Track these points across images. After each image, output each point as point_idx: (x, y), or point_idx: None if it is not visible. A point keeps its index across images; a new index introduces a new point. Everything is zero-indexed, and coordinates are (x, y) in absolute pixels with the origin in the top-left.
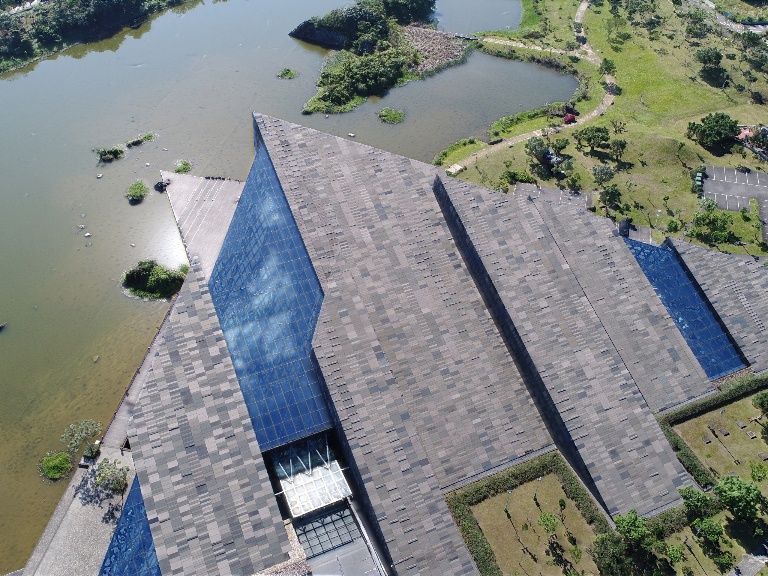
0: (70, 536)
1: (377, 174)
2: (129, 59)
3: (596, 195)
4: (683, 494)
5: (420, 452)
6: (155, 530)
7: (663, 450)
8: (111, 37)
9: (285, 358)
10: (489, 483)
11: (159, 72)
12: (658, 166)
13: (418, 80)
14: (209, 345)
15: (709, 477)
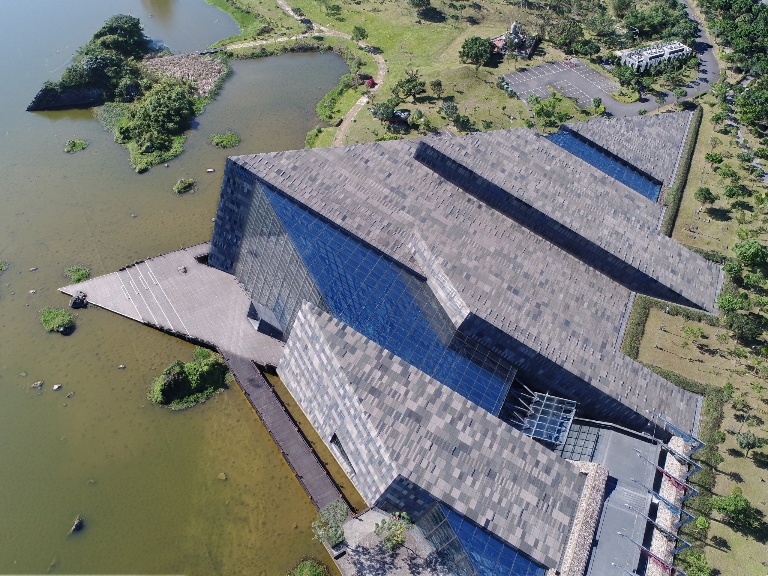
0: None
1: (368, 165)
2: None
3: (452, 129)
4: (729, 269)
5: (596, 340)
6: (495, 529)
7: (689, 254)
8: None
9: (443, 342)
10: (631, 338)
11: None
12: (471, 90)
13: (211, 102)
14: (389, 366)
15: (719, 255)
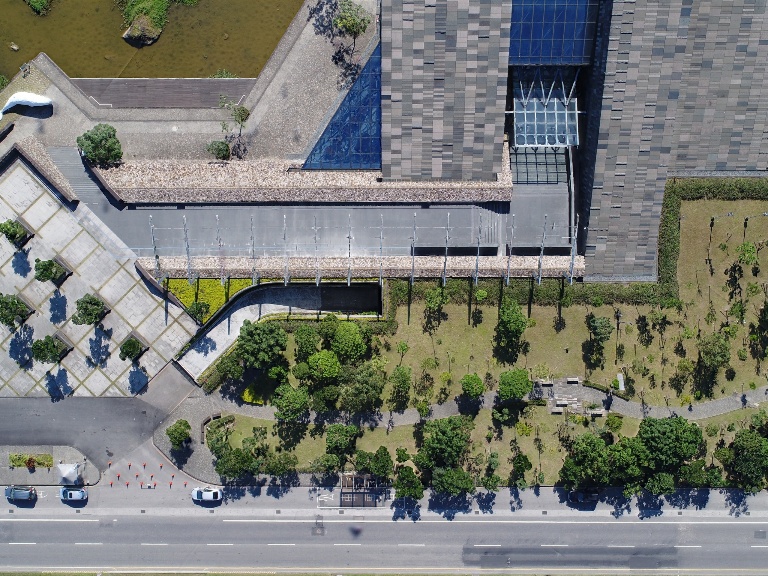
0: (301, 63)
1: None
2: None
3: None
4: None
5: (667, 138)
6: (386, 107)
7: None
8: None
9: None
10: (713, 186)
11: None
12: None
13: None
14: None
15: None
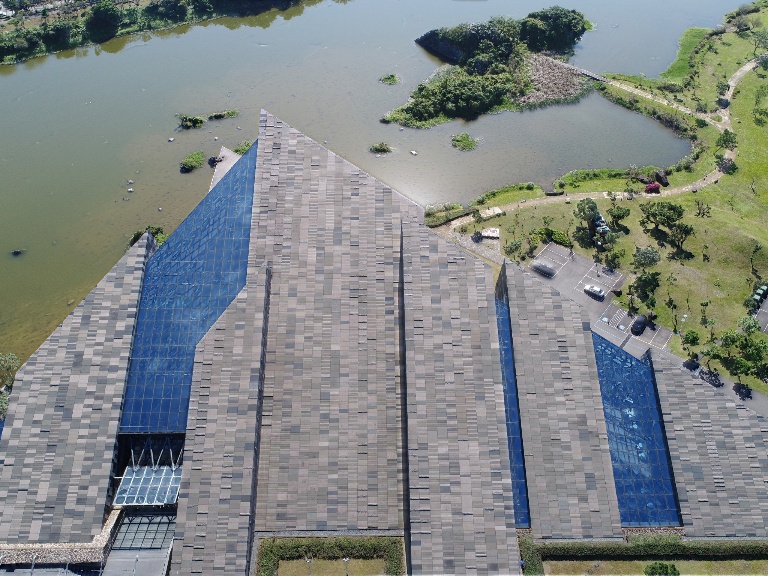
0: None
1: (352, 197)
2: (259, 38)
3: (631, 278)
4: None
5: (246, 487)
6: None
7: None
8: (257, 15)
9: (181, 352)
10: (311, 544)
11: (277, 55)
12: (721, 265)
13: (515, 111)
14: (119, 319)
15: None
